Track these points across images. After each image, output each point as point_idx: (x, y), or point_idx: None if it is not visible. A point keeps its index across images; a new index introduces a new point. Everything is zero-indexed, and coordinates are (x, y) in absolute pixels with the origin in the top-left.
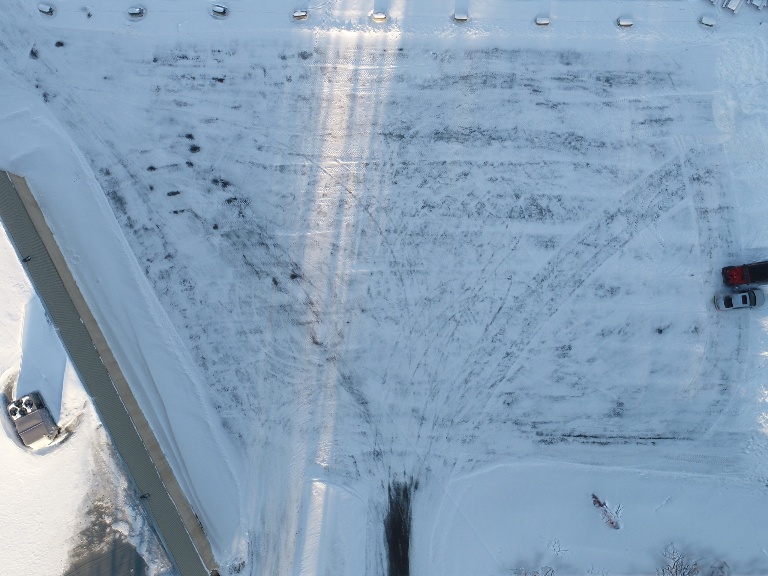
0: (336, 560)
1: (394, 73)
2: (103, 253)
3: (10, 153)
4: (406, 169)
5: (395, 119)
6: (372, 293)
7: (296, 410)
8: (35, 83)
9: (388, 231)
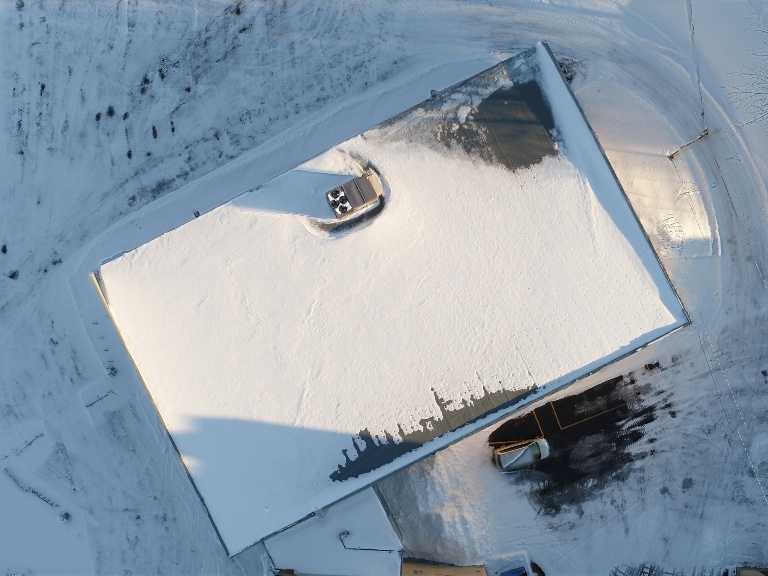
0: None
1: None
2: (212, 199)
3: None
4: None
5: None
6: None
7: (370, 8)
8: (43, 273)
9: None
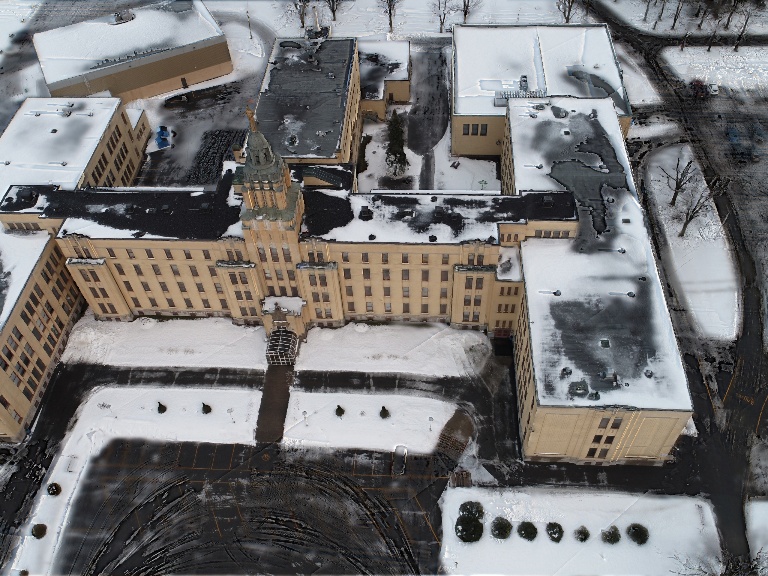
0: (208, 4)
1: (54, 4)
2: None
3: (36, 73)
4: (86, 0)
5: (69, 3)
6: (124, 4)
7: None
8: None
9: (105, 2)
